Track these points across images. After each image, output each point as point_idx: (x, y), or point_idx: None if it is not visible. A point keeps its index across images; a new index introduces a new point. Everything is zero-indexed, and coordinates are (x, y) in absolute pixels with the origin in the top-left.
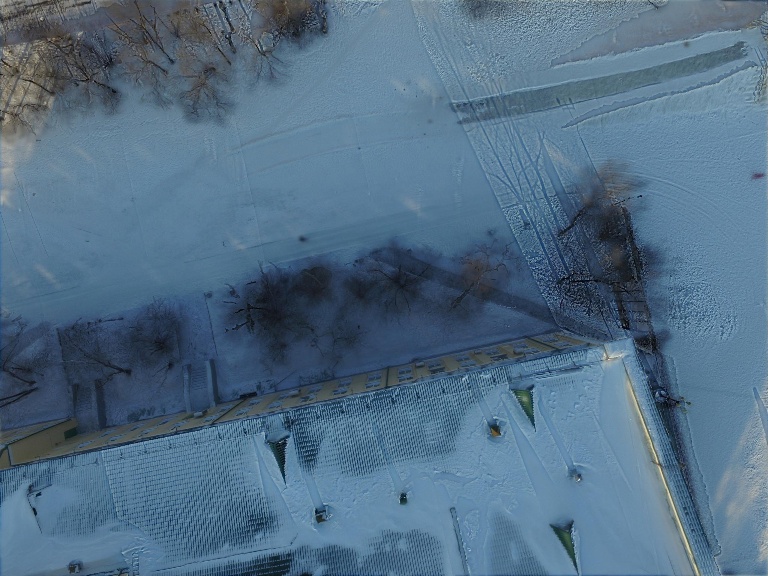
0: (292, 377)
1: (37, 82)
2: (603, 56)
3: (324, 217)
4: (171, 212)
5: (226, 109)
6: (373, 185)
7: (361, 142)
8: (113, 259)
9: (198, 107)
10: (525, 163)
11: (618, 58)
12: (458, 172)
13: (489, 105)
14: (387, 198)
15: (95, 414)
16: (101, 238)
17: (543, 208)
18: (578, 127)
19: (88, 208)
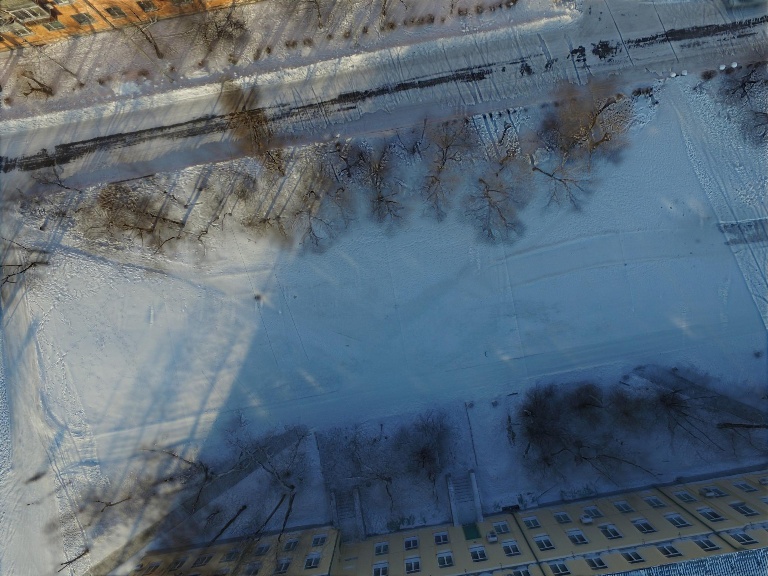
0: (552, 490)
1: (303, 186)
2: None
3: (588, 331)
4: (433, 320)
5: (517, 231)
6: (637, 301)
7: (627, 258)
8: (373, 365)
9: (490, 228)
10: None
11: None
12: (724, 292)
13: (757, 227)
14: (651, 315)
15: (360, 523)
16: (361, 343)
17: None
18: None
19: (350, 313)
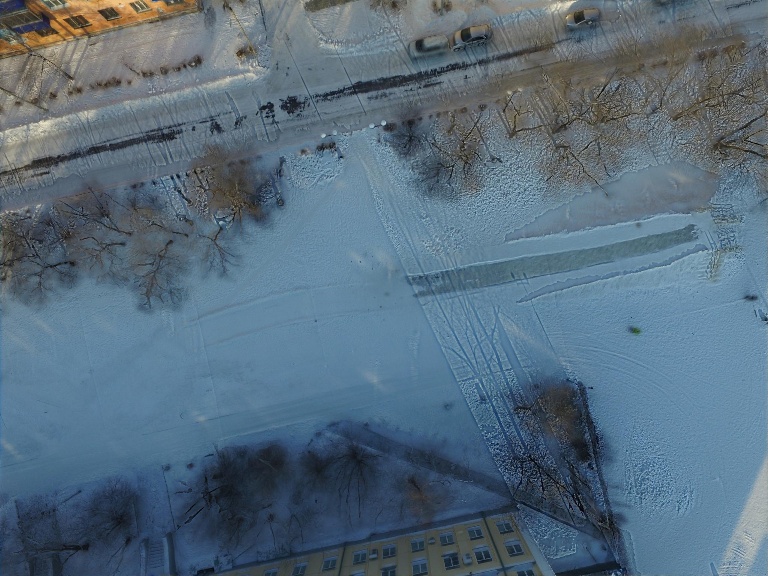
0: (250, 551)
1: None
2: (556, 234)
3: (281, 389)
4: (129, 383)
5: (179, 297)
6: (330, 357)
7: (318, 314)
8: (71, 430)
9: None
10: (481, 337)
11: (571, 236)
12: (414, 345)
13: (444, 279)
14: (344, 370)
15: None
16: (59, 409)
17: (499, 382)
18: (533, 302)
19: (46, 380)
